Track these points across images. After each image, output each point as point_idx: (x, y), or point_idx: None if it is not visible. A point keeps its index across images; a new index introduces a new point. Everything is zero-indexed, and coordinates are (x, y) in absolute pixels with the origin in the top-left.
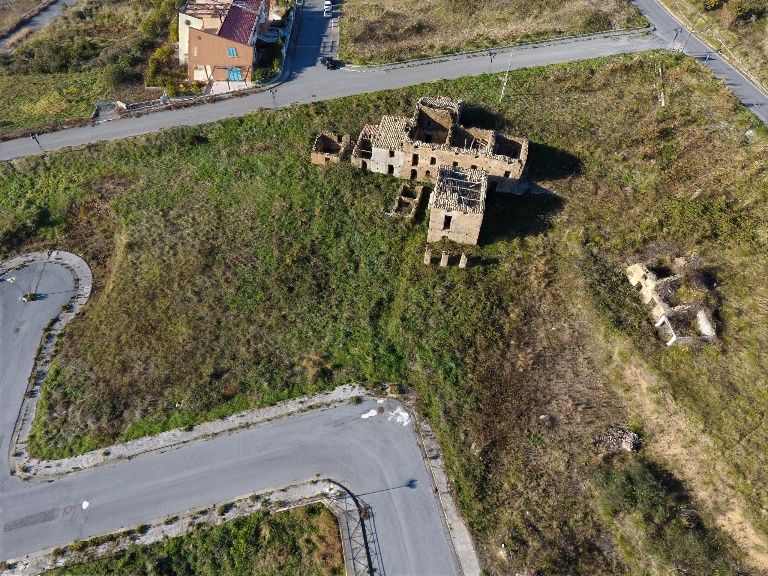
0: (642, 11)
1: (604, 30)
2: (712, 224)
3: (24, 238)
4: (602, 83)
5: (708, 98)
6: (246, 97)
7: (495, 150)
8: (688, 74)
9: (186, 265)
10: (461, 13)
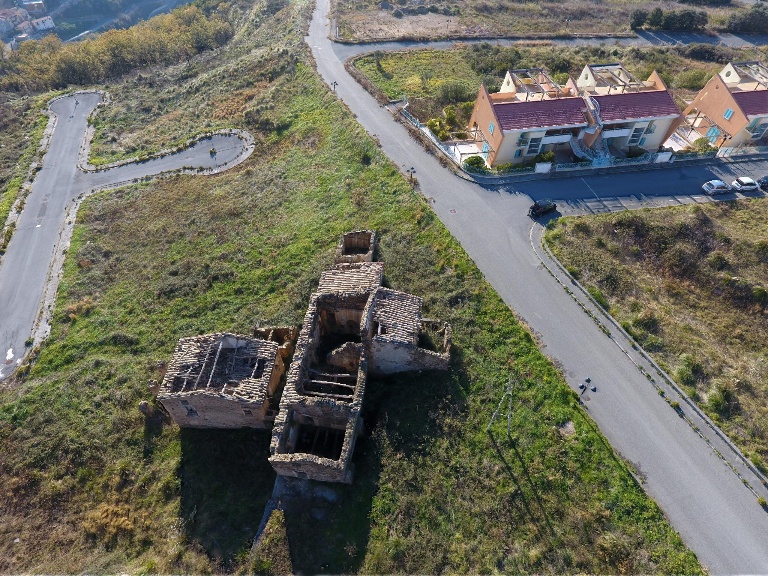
0: None
1: None
2: None
3: (265, 129)
4: None
5: None
6: (440, 166)
7: None
8: None
9: (222, 206)
10: None
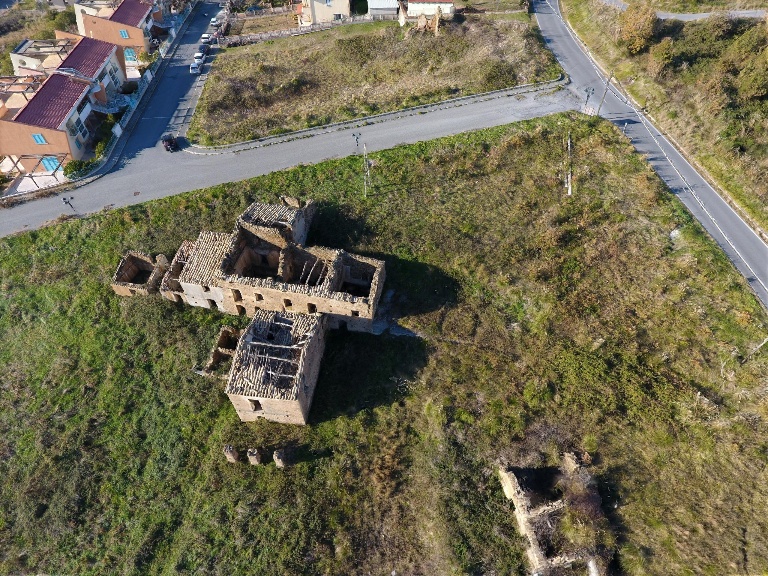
0: (558, 57)
1: (507, 86)
2: (618, 393)
3: None
4: (495, 165)
5: (625, 182)
6: (53, 198)
7: (347, 272)
8: (602, 148)
9: None
10: (351, 63)
